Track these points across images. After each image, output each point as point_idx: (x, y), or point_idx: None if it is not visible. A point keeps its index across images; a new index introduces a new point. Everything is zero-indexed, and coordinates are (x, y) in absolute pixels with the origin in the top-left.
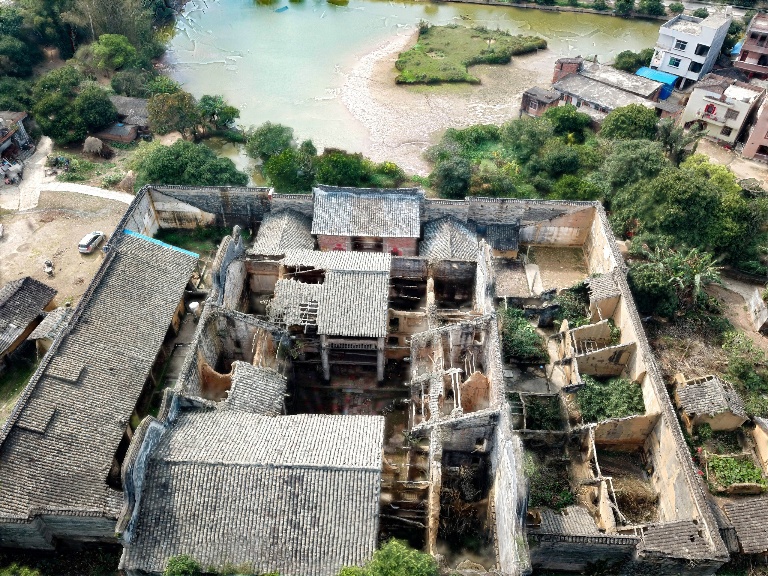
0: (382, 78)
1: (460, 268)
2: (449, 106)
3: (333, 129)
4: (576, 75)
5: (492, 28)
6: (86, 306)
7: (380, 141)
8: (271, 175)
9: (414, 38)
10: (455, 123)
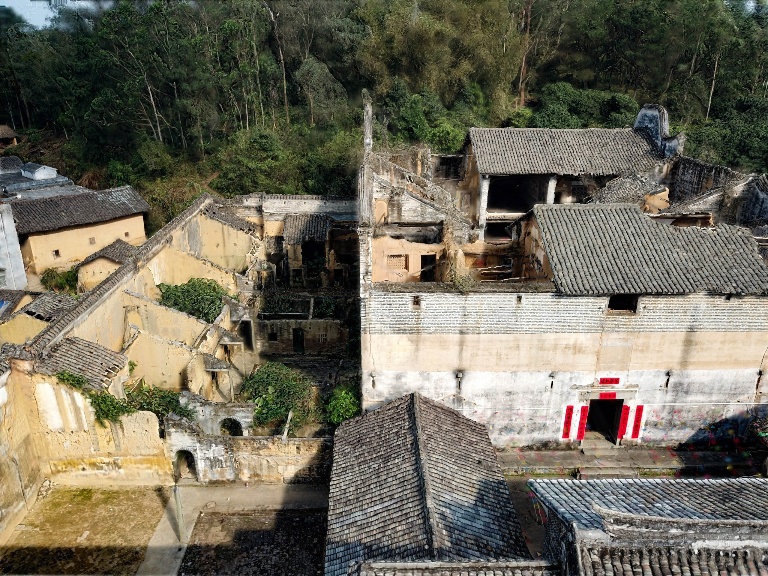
0: None
1: None
2: None
3: None
4: None
5: None
6: None
7: None
8: None
9: None
10: None
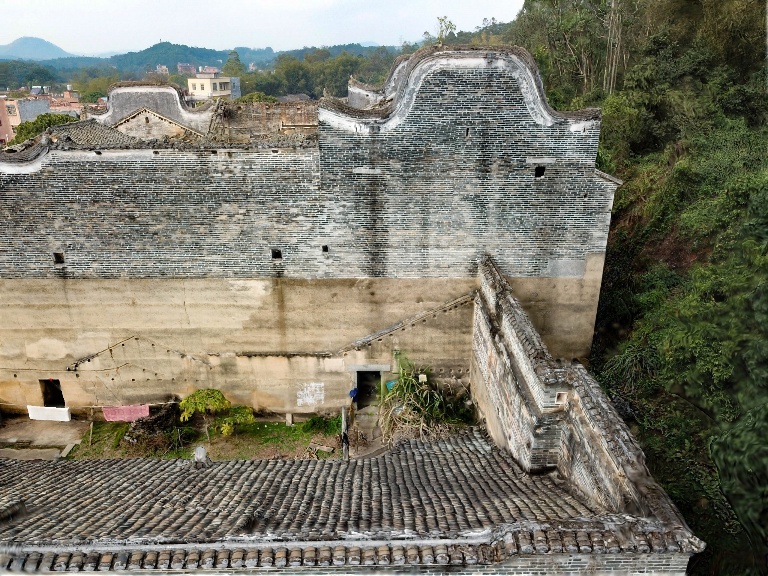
0: None
1: None
2: None
3: None
4: None
5: None
6: None
7: None
8: None
9: None
10: None
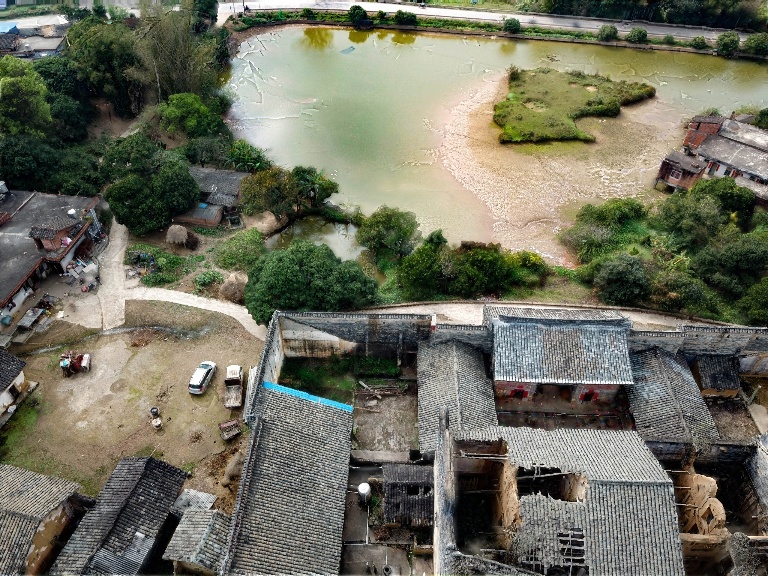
0: (482, 136)
1: (730, 451)
2: (568, 171)
3: (444, 203)
4: (718, 137)
5: (590, 73)
6: (243, 515)
7: (502, 219)
8: (406, 280)
9: (504, 85)
10: (582, 194)
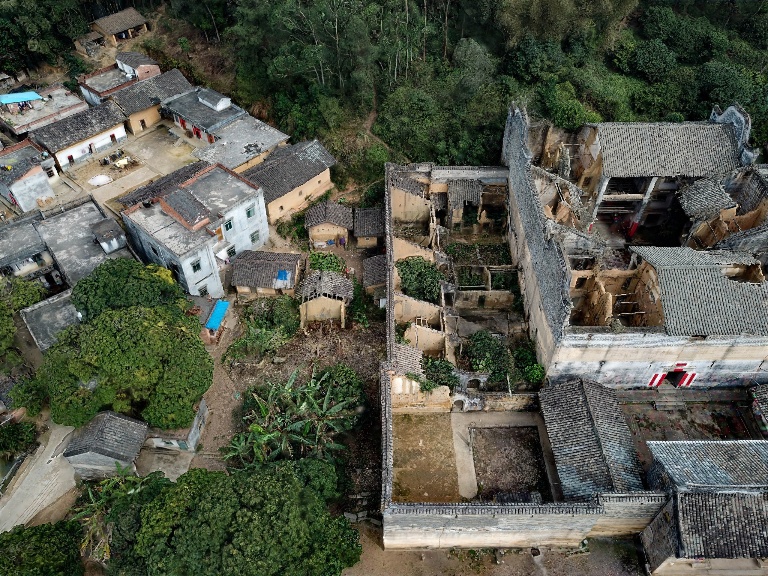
0: None
1: None
2: None
3: None
4: None
5: None
6: None
7: None
8: None
9: None
10: None
